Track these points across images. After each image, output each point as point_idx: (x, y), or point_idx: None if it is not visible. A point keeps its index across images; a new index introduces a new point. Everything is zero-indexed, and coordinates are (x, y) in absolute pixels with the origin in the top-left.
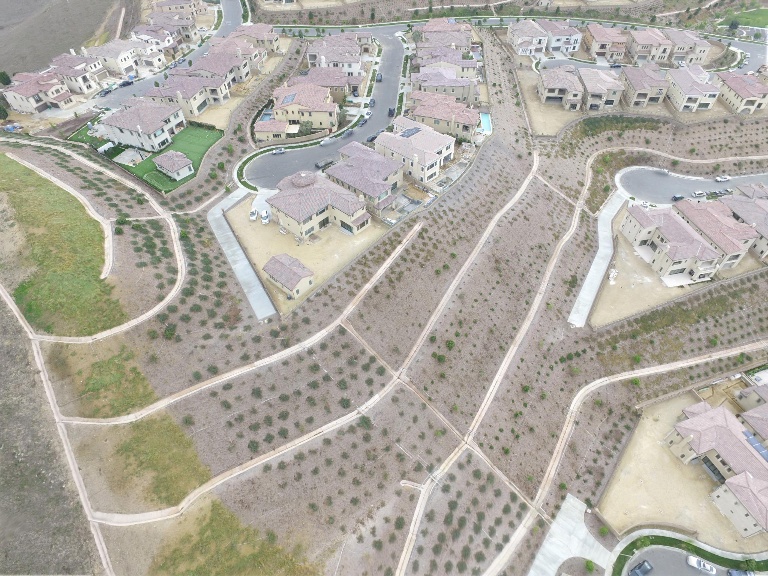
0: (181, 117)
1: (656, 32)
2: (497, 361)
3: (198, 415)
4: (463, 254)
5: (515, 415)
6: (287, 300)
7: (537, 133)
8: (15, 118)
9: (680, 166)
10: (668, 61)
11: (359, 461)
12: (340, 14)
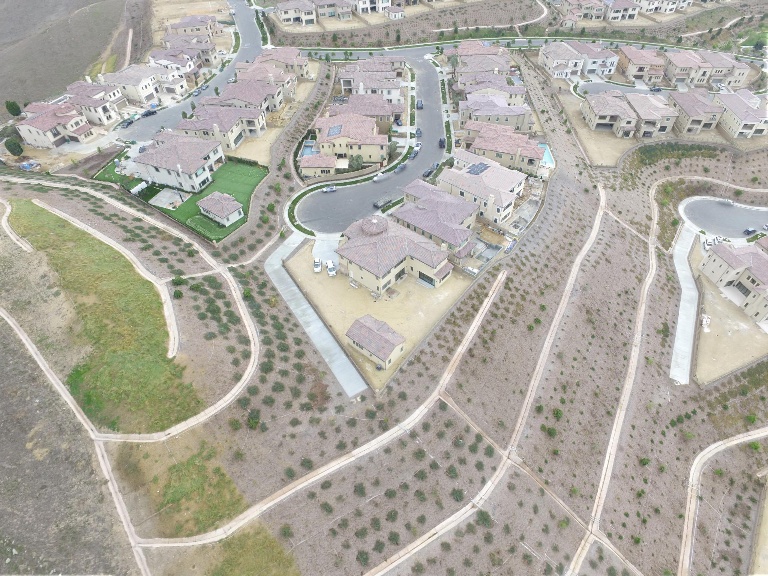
0: (220, 152)
1: (693, 54)
2: (607, 429)
3: (296, 524)
4: (552, 305)
5: (638, 495)
6: (377, 371)
7: (595, 163)
8: (30, 154)
9: (744, 196)
10: (707, 84)
11: (483, 568)
12: (365, 36)
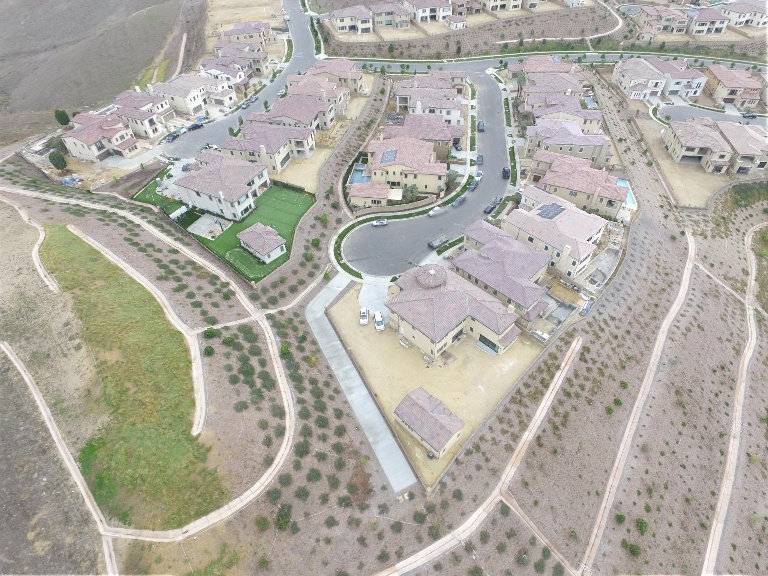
0: (265, 177)
1: None
2: (700, 547)
3: None
4: (634, 382)
5: None
6: (428, 459)
7: (681, 203)
8: (74, 167)
9: None
10: None
11: None
12: (423, 47)
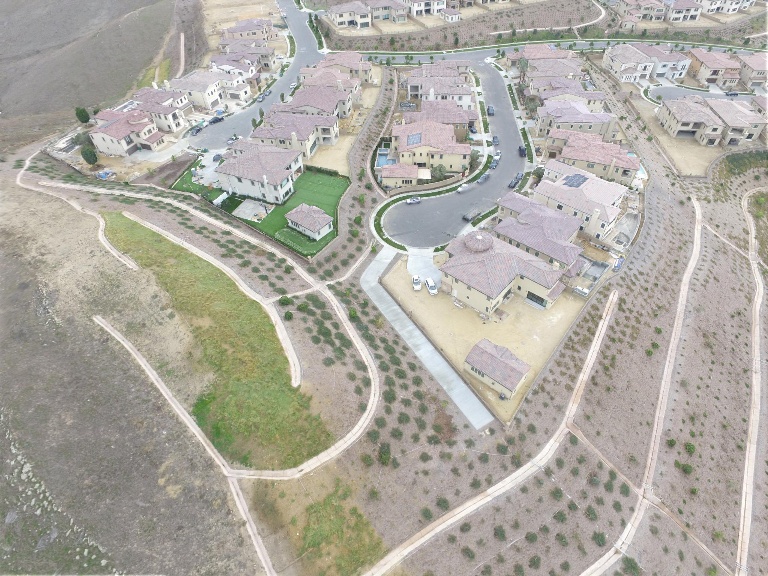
0: (300, 162)
1: None
2: (739, 465)
3: (439, 570)
4: (666, 328)
5: None
6: (500, 400)
7: (682, 173)
8: (103, 162)
9: None
10: None
11: None
12: (422, 39)
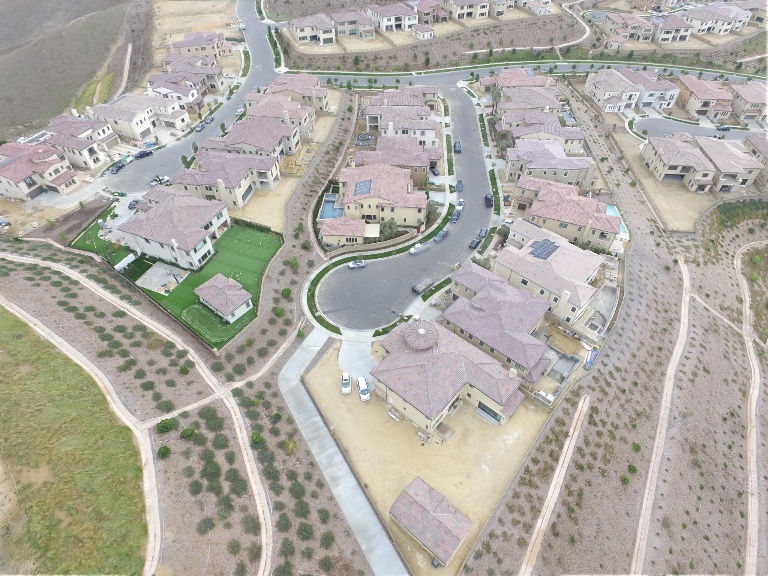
0: (225, 216)
1: (764, 87)
2: None
3: None
4: (647, 441)
5: None
6: (433, 568)
7: (669, 226)
8: None
9: None
10: None
11: None
12: (390, 59)
